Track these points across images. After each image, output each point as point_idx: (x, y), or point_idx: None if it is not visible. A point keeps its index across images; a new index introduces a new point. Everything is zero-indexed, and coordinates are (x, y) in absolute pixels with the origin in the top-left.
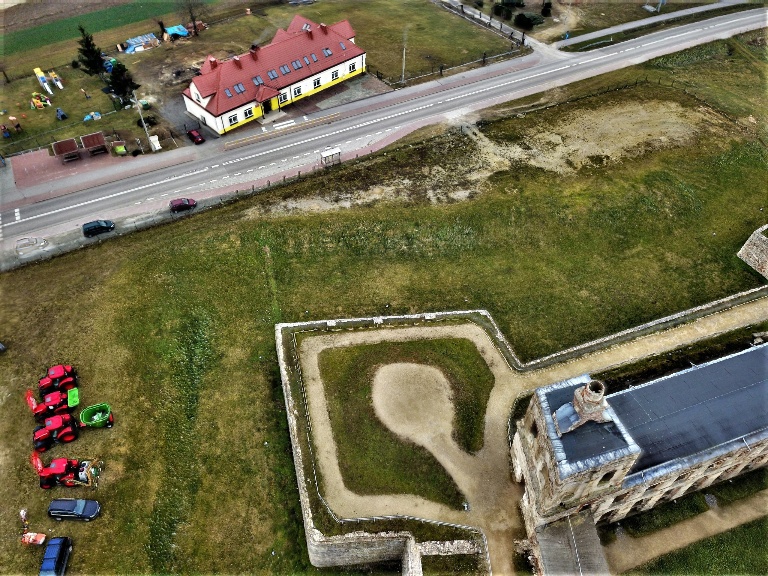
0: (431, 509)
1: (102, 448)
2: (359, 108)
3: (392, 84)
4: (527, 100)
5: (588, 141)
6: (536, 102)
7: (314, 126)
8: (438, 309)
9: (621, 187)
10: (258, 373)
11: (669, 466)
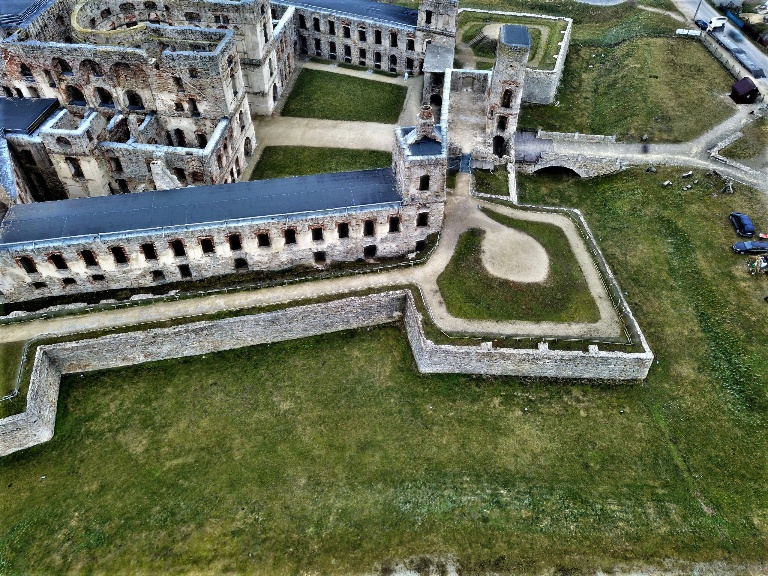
0: (502, 211)
1: (761, 285)
2: None
3: None
4: None
5: None
6: None
7: None
8: (466, 400)
9: (113, 573)
10: (654, 348)
11: None
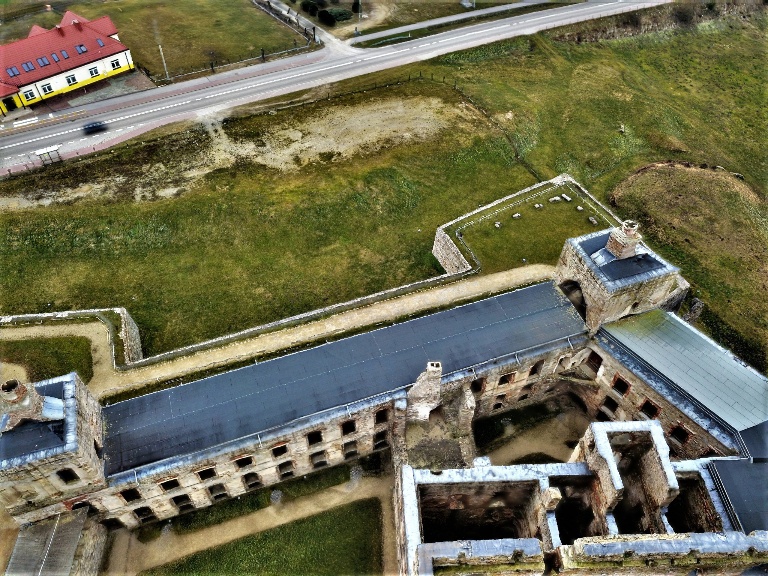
0: None
1: None
2: (111, 105)
3: (157, 81)
4: (289, 97)
5: (328, 138)
6: (296, 99)
7: (56, 123)
8: (100, 307)
9: (338, 184)
10: None
11: (169, 463)
